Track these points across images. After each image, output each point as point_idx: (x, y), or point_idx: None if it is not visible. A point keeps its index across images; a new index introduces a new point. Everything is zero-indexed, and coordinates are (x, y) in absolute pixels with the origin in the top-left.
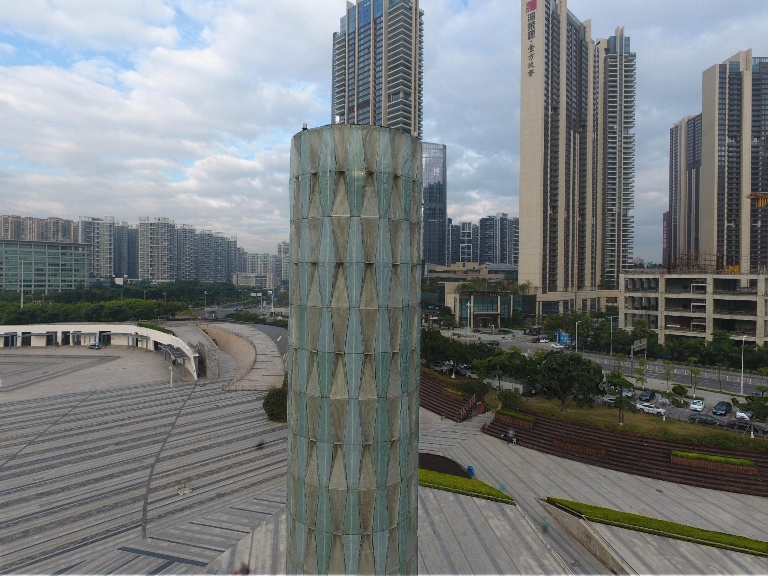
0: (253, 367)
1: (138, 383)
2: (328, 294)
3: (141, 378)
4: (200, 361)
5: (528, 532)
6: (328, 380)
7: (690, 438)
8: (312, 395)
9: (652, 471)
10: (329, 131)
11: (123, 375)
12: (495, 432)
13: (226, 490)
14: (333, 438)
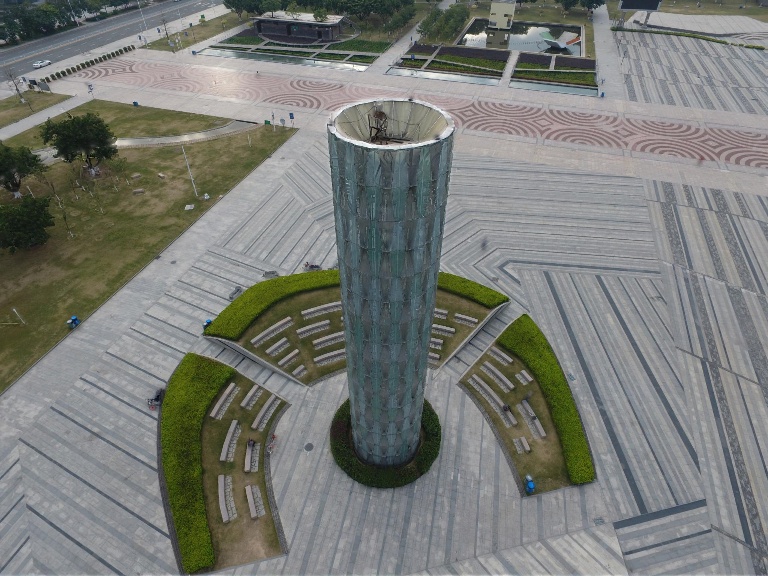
0: None
1: None
2: None
3: None
4: None
5: None
6: None
7: None
8: None
9: None
10: None
11: None
12: None
13: None
14: None
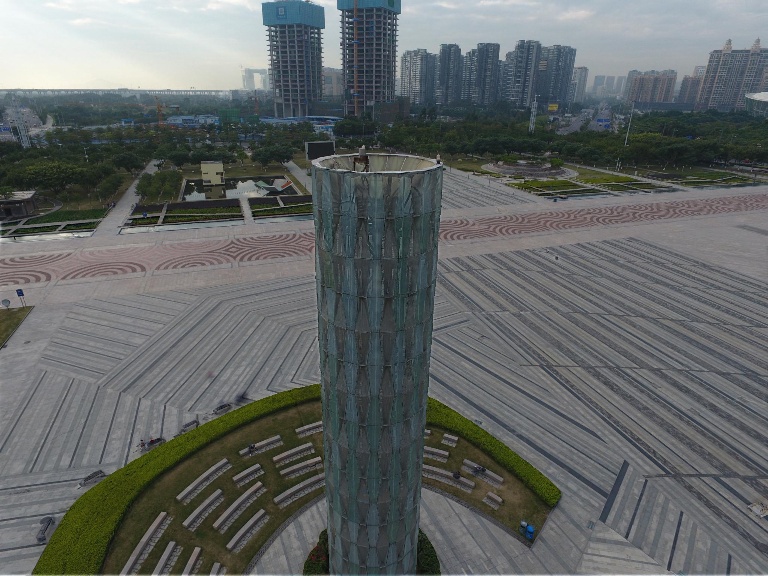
0: None
1: None
2: None
3: None
4: None
5: None
6: None
7: None
8: None
9: None
10: None
11: None
12: None
13: None
14: None
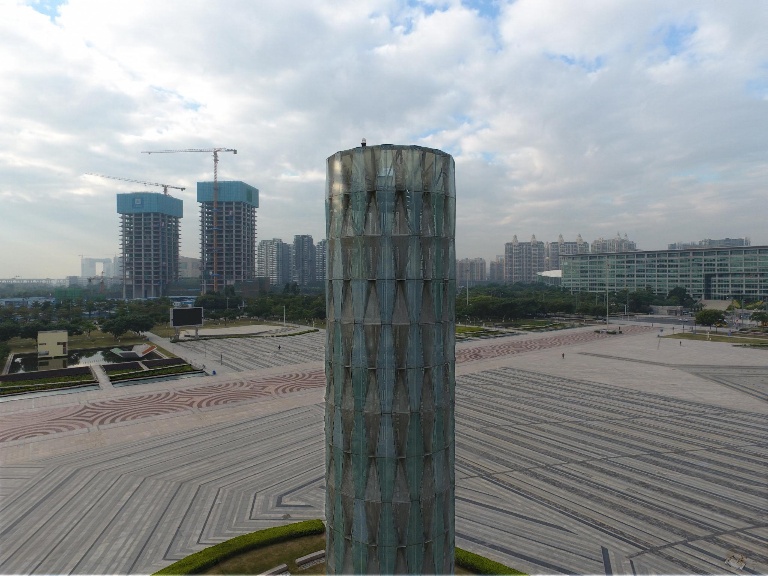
0: None
1: None
2: None
3: None
4: None
5: None
6: None
7: None
8: None
9: None
10: None
11: None
12: None
13: None
14: None
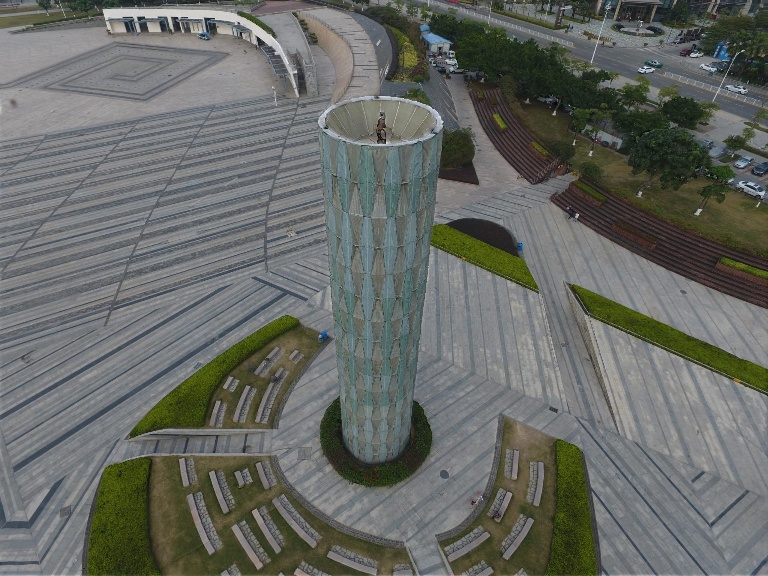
0: (350, 85)
1: (248, 98)
2: (349, 260)
3: (250, 90)
4: (300, 74)
5: (538, 317)
6: (352, 306)
7: (750, 249)
8: (342, 309)
9: (690, 272)
10: (343, 146)
11: (234, 84)
12: (563, 203)
13: (321, 237)
14: (356, 335)
